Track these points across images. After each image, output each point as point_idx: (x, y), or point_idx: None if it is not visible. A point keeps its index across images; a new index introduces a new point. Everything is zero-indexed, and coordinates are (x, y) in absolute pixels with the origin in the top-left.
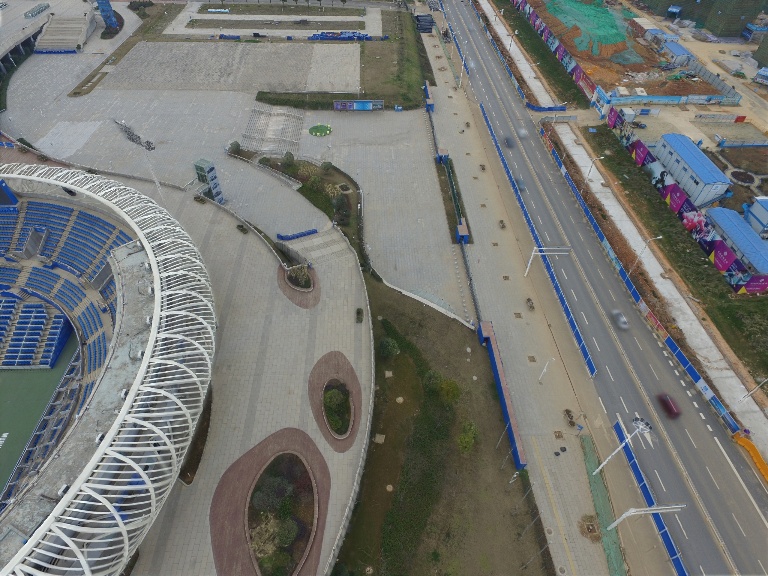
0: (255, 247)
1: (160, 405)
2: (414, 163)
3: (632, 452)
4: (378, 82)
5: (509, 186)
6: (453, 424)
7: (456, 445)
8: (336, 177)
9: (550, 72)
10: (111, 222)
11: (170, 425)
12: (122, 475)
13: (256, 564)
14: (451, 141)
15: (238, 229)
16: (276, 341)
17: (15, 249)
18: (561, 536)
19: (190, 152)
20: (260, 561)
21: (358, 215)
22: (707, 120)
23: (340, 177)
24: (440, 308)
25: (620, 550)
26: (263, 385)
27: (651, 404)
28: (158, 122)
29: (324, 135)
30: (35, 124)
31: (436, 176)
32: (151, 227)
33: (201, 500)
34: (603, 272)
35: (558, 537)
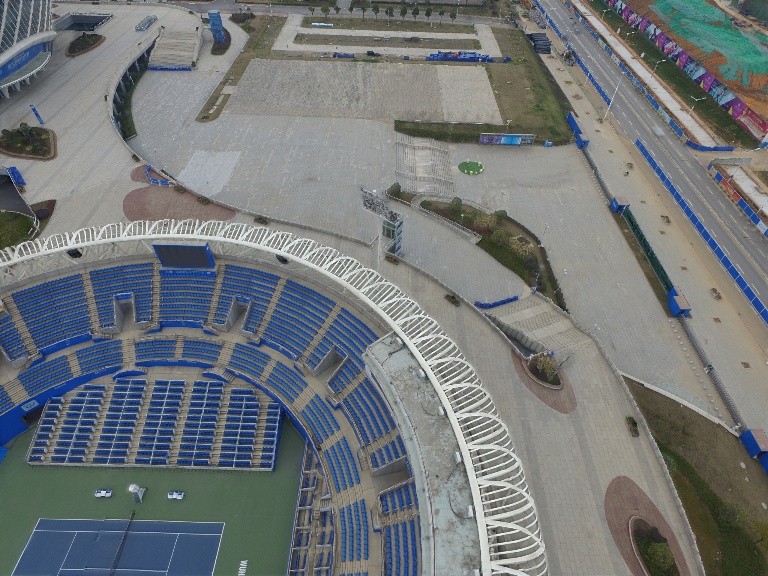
0: (475, 325)
1: None
2: (587, 211)
3: None
4: (519, 112)
5: (704, 244)
6: None
7: None
8: (509, 227)
9: (697, 103)
10: (329, 296)
11: None
12: None
13: None
14: (618, 185)
15: (447, 300)
16: (546, 458)
17: (214, 320)
18: None
19: (345, 192)
20: None
21: (551, 277)
22: None
23: (513, 227)
24: (700, 410)
25: None
26: (554, 523)
27: None
28: (300, 154)
29: (477, 174)
30: (171, 153)
31: (618, 229)
32: (403, 317)
33: None
34: None
35: None
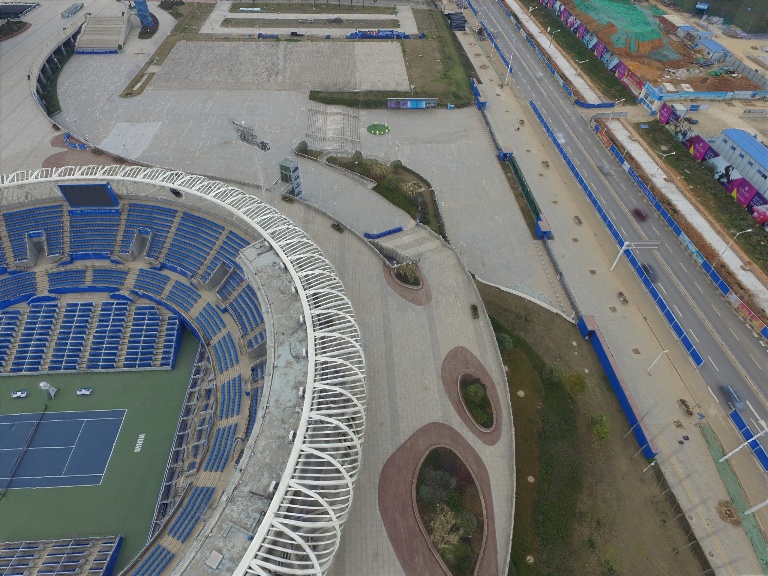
0: (354, 246)
1: (339, 402)
2: (478, 161)
3: (756, 439)
4: (426, 80)
5: (575, 182)
6: (578, 416)
7: (585, 436)
8: (405, 175)
9: (590, 69)
10: (219, 223)
11: (352, 421)
12: (325, 471)
13: (438, 555)
14: (509, 138)
15: (333, 228)
16: (399, 338)
17: (120, 251)
18: (702, 521)
19: None
20: (441, 552)
21: (436, 213)
22: (755, 115)
23: (409, 175)
24: (542, 303)
25: (761, 533)
26: (398, 381)
27: (761, 392)
28: (218, 122)
29: (383, 134)
30: (94, 125)
31: (502, 173)
32: (273, 227)
33: (367, 495)
34: (685, 265)
35: (700, 522)
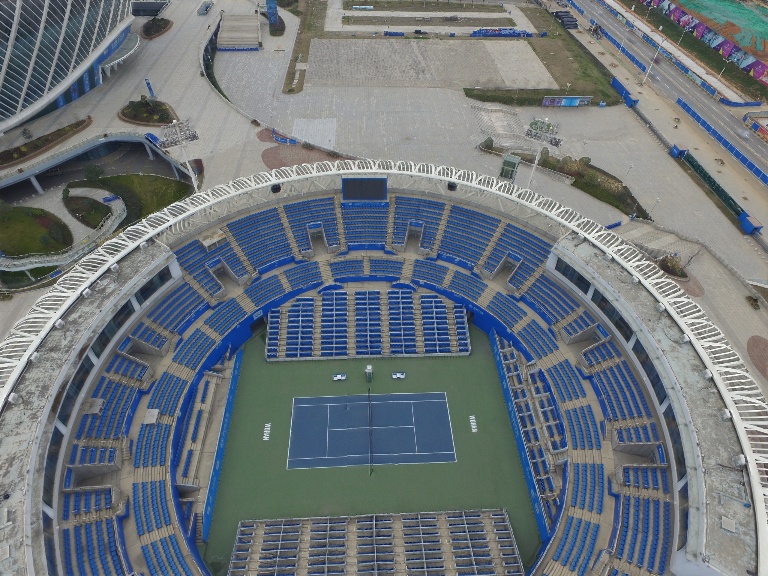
0: None
1: (748, 383)
2: (652, 158)
3: None
4: (570, 78)
5: (756, 179)
6: None
7: None
8: None
9: (719, 68)
10: (493, 216)
11: None
12: None
13: None
14: (672, 136)
15: None
16: None
17: (393, 242)
18: None
19: (442, 148)
20: None
21: (640, 208)
22: None
23: None
24: None
25: None
26: None
27: None
28: (390, 119)
29: None
30: (273, 121)
31: (682, 170)
32: (576, 220)
33: None
34: None
35: None
